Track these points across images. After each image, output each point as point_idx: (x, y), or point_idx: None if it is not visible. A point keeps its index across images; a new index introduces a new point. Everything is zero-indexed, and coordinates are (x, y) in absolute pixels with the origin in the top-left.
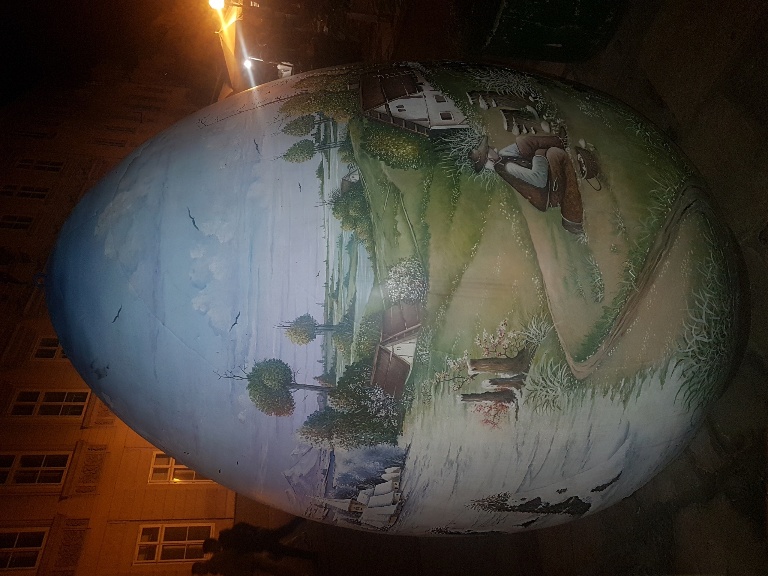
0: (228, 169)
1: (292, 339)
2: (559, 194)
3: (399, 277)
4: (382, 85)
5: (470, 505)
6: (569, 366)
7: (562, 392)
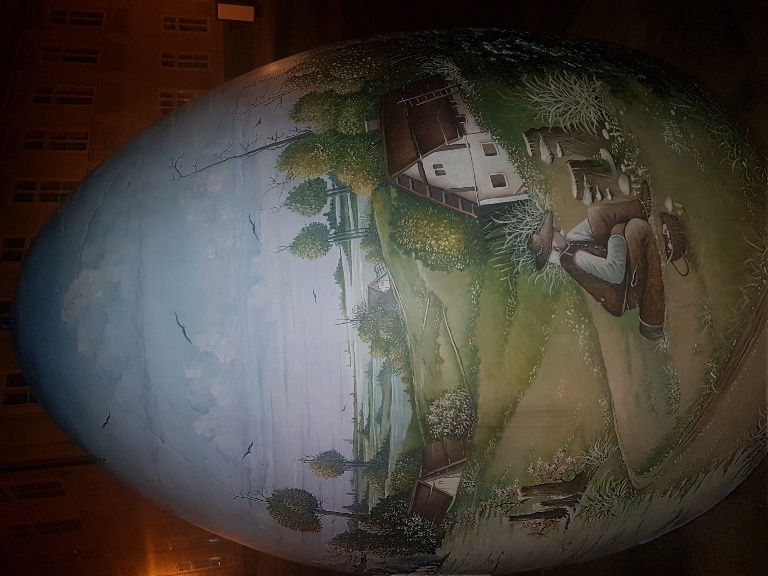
0: (219, 260)
1: (316, 472)
2: (638, 290)
3: (442, 411)
4: (411, 123)
5: (505, 574)
6: (630, 480)
7: (619, 502)
